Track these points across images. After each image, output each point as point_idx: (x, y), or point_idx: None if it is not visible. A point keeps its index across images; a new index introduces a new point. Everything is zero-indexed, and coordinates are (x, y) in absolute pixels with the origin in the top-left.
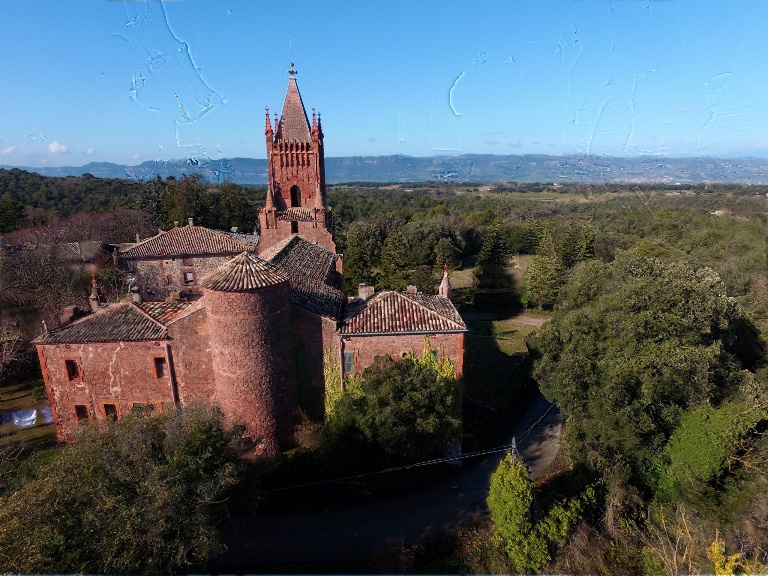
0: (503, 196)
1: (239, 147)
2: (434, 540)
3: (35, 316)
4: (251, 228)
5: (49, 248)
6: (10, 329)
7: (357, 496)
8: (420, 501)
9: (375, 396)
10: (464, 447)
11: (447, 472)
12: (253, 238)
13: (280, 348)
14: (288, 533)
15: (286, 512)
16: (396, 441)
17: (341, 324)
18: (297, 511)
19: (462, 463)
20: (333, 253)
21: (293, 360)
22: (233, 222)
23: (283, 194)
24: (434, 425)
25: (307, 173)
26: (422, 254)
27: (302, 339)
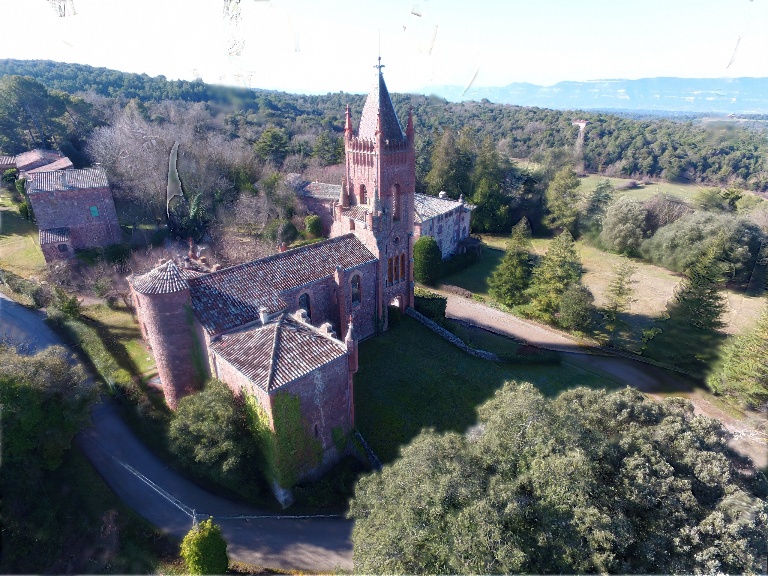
0: (729, 219)
1: (504, 102)
2: (171, 539)
3: (219, 249)
4: (509, 186)
5: (283, 194)
6: (209, 253)
7: (193, 472)
8: (213, 508)
9: (179, 409)
10: (294, 495)
11: (267, 504)
12: (449, 206)
13: (173, 340)
14: (133, 465)
15: (152, 452)
16: (173, 451)
17: (219, 338)
18: (156, 455)
19: (287, 507)
20: (377, 257)
21: (192, 351)
22: (483, 179)
23: (355, 190)
24: (203, 457)
25: (371, 174)
26: (684, 260)
27: (199, 338)
